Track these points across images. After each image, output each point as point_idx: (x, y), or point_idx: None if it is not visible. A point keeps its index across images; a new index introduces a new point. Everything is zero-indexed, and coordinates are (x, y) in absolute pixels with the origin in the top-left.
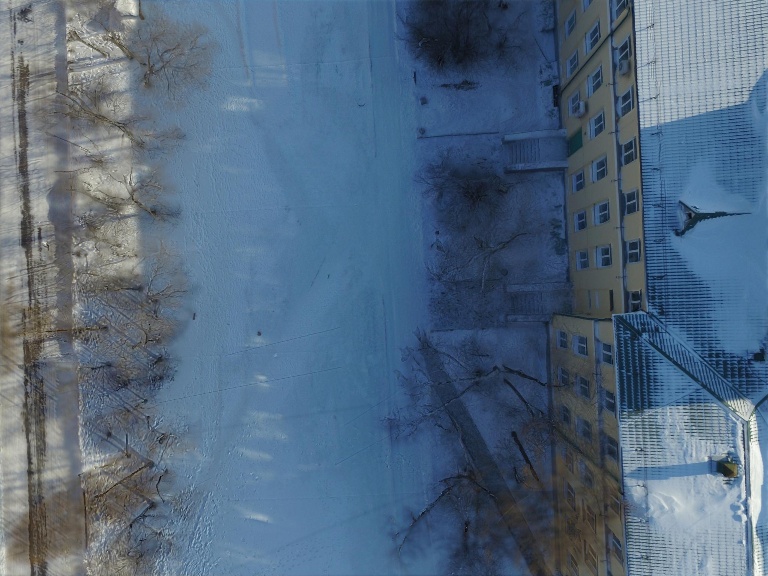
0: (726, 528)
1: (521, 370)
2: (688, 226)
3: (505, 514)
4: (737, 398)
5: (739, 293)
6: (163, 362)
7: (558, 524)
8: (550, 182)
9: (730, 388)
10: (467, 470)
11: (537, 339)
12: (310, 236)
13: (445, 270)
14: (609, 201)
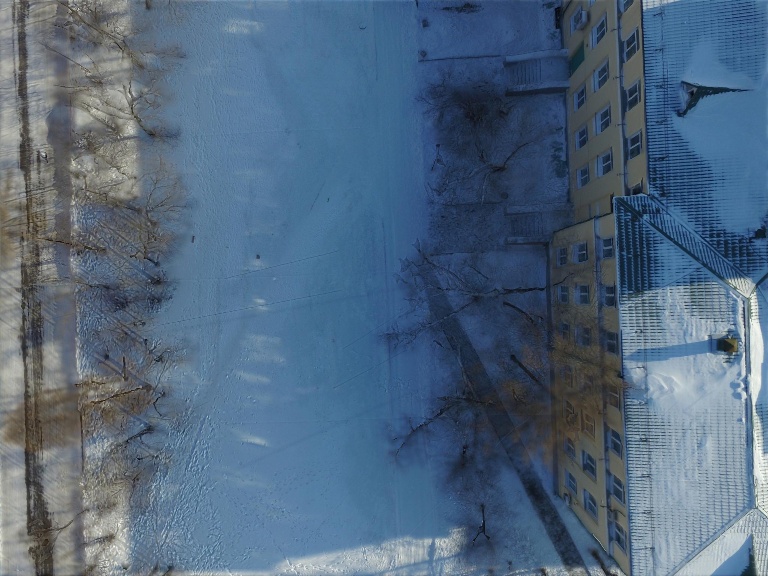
0: (726, 406)
1: (521, 287)
2: (690, 104)
3: (503, 439)
4: (738, 277)
5: (741, 172)
6: (161, 285)
7: (556, 446)
8: (551, 105)
9: (731, 267)
10: (466, 393)
11: (537, 262)
12: (310, 159)
13: (445, 181)
14: (611, 104)
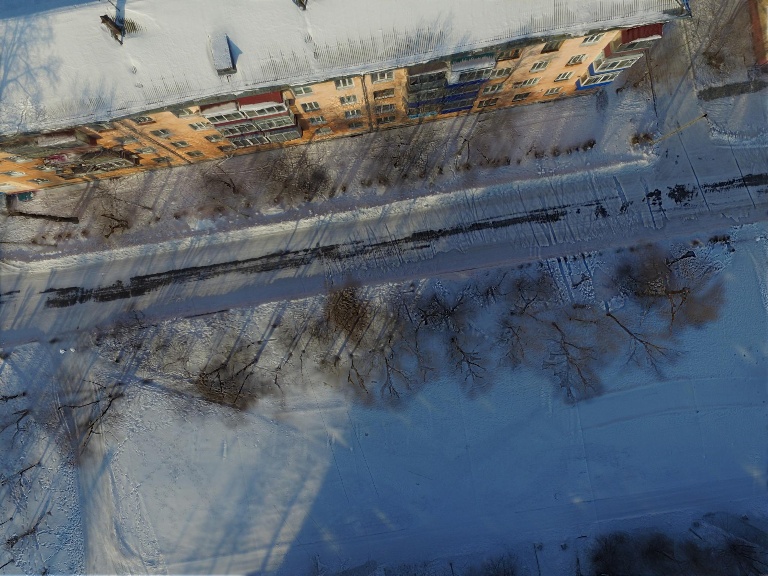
0: None
1: None
2: None
3: None
4: None
5: None
6: None
7: None
8: None
9: None
10: None
11: None
12: (448, 467)
13: None
14: None
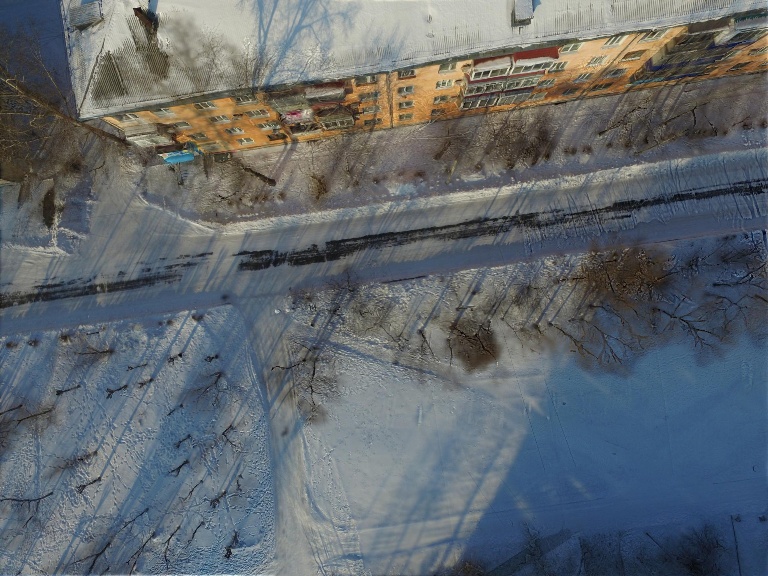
0: None
1: None
2: None
3: None
4: None
5: None
6: (535, 330)
7: None
8: None
9: None
10: (478, 575)
11: None
12: (646, 437)
13: (653, 570)
14: None
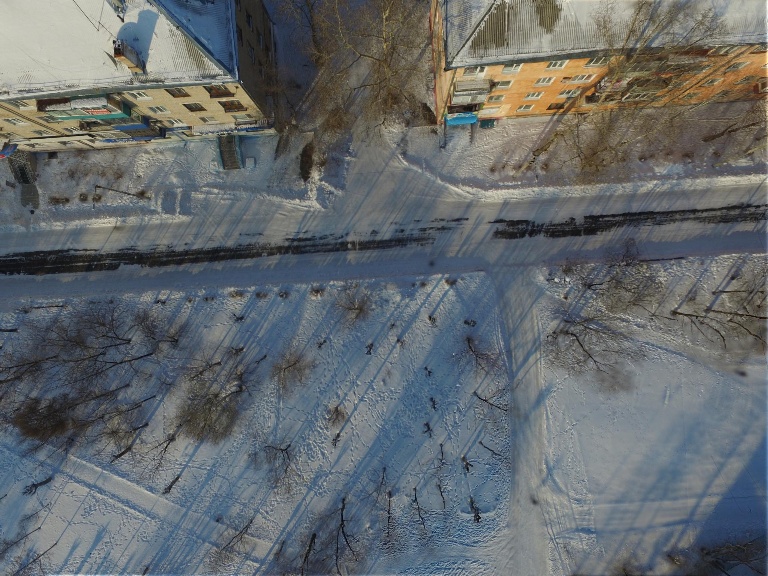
0: None
1: None
2: None
3: None
4: None
5: None
6: None
7: None
8: None
9: None
10: (716, 559)
11: None
12: None
13: None
14: None
